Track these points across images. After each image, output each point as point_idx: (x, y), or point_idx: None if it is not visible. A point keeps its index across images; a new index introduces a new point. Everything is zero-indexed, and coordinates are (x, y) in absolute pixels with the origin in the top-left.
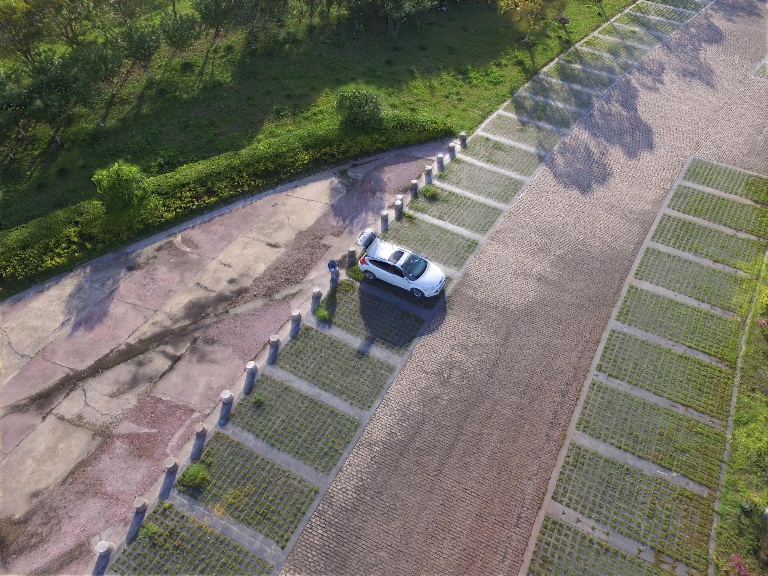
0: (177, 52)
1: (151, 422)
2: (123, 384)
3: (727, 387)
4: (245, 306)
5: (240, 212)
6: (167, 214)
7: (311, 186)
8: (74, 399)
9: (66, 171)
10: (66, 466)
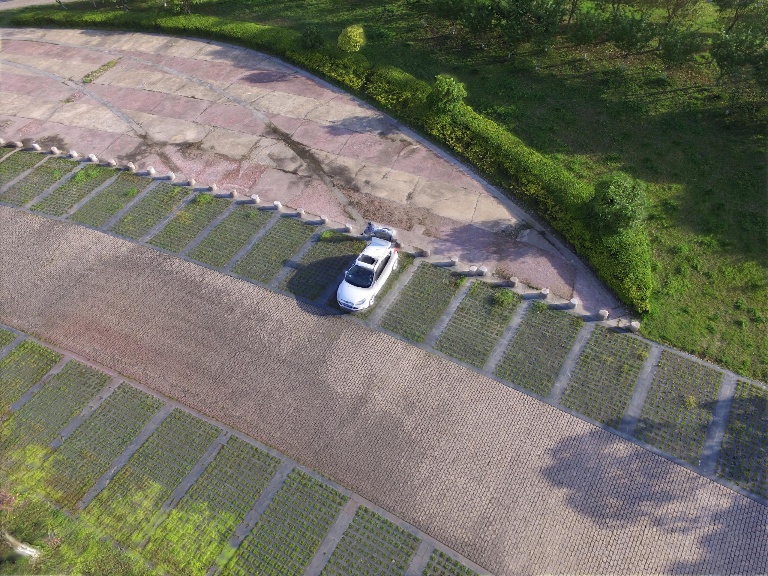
0: (682, 69)
1: (246, 174)
2: (277, 156)
3: (179, 570)
4: (339, 194)
5: (451, 170)
6: (435, 131)
7: (498, 207)
8: (270, 142)
9: (475, 73)
10: (225, 151)
